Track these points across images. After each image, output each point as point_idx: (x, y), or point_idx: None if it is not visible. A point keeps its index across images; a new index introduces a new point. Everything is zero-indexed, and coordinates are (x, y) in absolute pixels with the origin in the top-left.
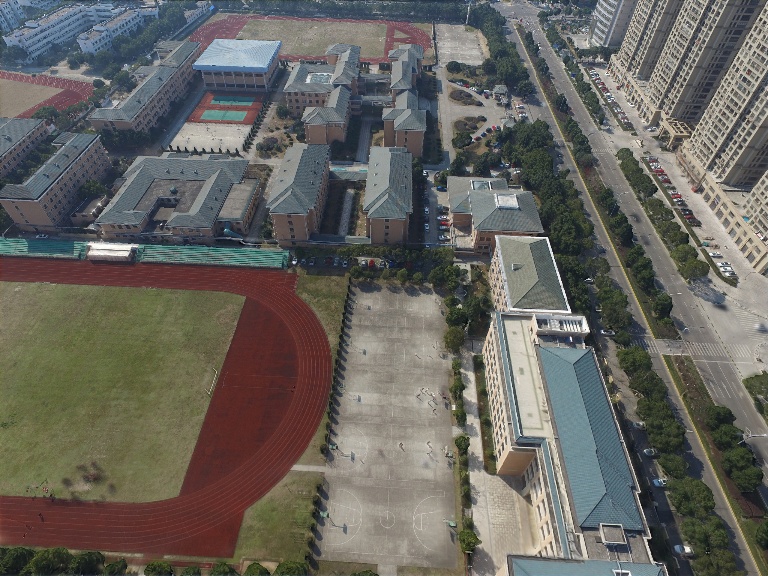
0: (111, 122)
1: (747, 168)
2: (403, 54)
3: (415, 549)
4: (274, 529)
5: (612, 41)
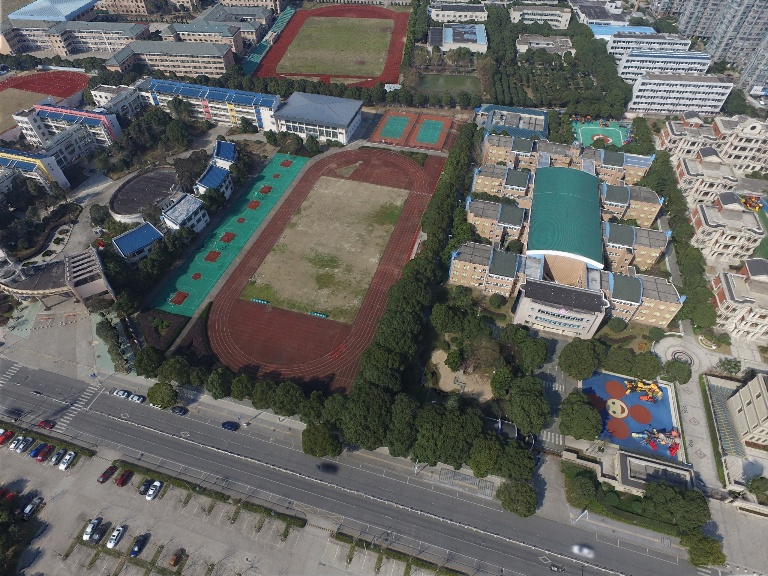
0: None
1: None
2: None
3: None
4: (402, 9)
5: None
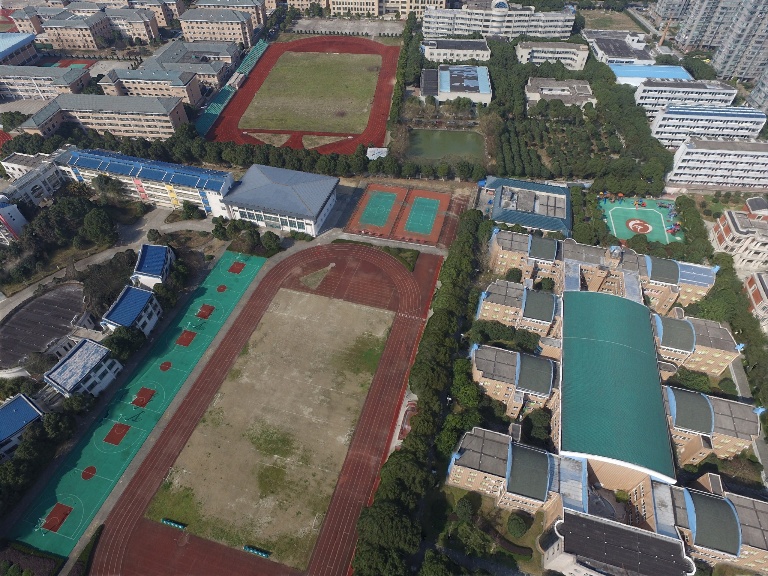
0: (80, 79)
1: None
2: None
3: (398, 26)
4: None
5: None
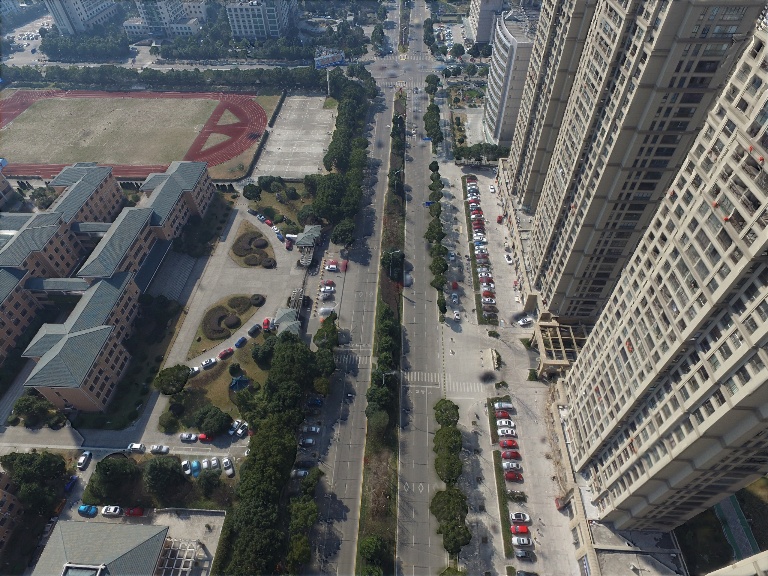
0: None
1: (640, 518)
2: (160, 184)
3: None
4: None
5: (504, 134)
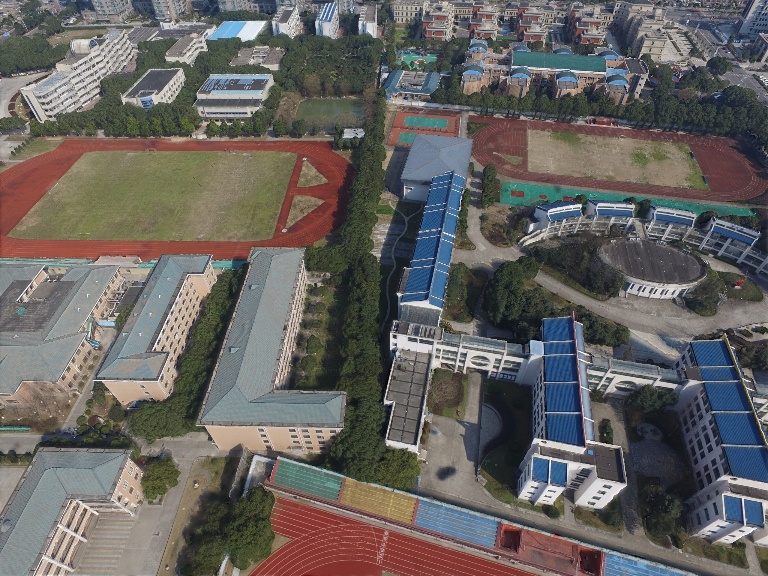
0: None
1: None
2: None
3: None
4: (43, 146)
5: None
